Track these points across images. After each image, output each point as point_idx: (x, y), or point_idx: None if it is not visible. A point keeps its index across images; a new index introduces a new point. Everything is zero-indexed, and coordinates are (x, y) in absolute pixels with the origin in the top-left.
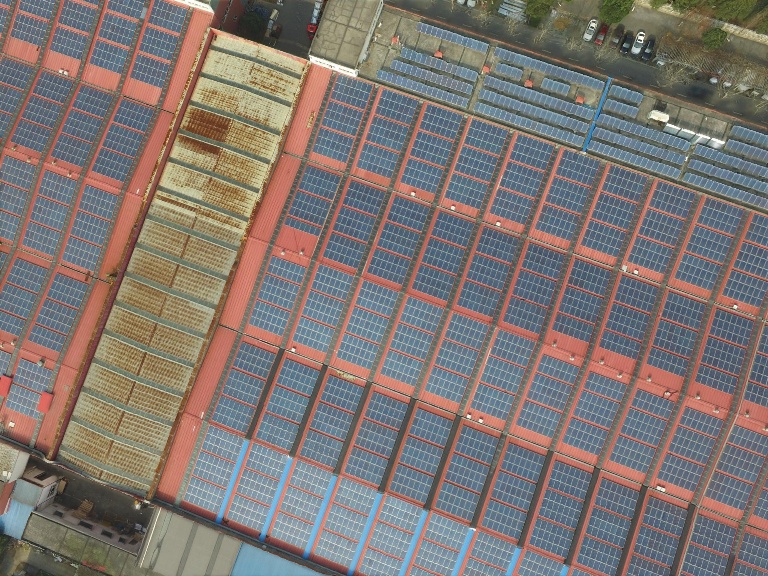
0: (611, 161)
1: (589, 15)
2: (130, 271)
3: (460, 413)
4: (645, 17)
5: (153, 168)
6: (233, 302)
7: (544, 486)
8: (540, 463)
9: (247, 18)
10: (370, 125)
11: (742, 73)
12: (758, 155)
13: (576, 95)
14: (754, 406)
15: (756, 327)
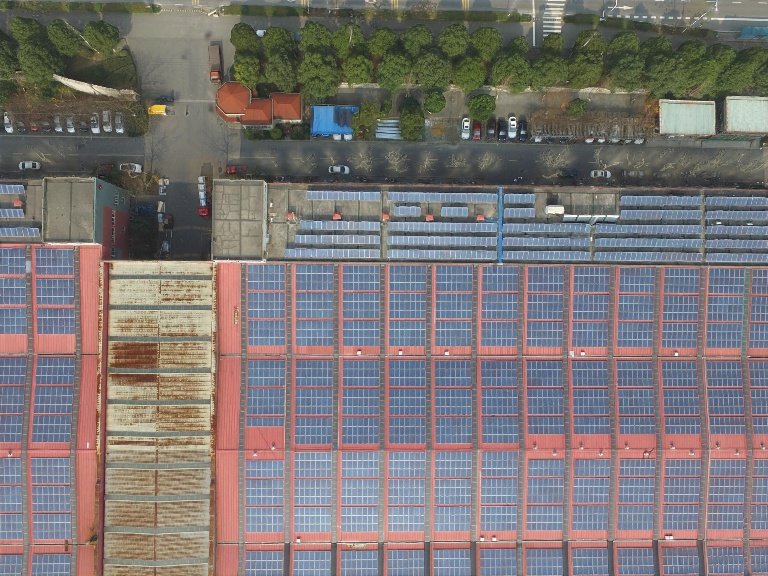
0: (527, 263)
1: (460, 114)
2: (109, 525)
3: (473, 539)
4: (510, 101)
5: (95, 417)
6: (223, 517)
7: (570, 575)
8: (559, 556)
9: (136, 227)
10: (295, 302)
11: (611, 129)
12: (650, 216)
13: (476, 212)
14: (721, 436)
15: (699, 365)
